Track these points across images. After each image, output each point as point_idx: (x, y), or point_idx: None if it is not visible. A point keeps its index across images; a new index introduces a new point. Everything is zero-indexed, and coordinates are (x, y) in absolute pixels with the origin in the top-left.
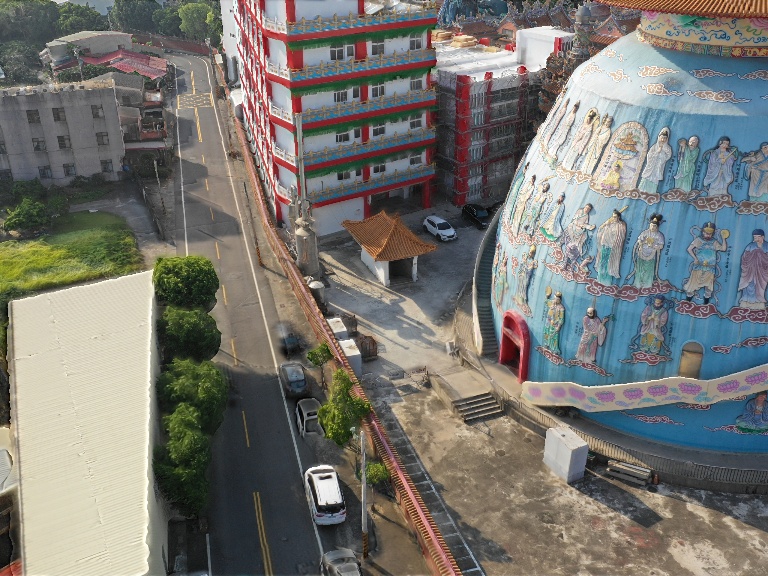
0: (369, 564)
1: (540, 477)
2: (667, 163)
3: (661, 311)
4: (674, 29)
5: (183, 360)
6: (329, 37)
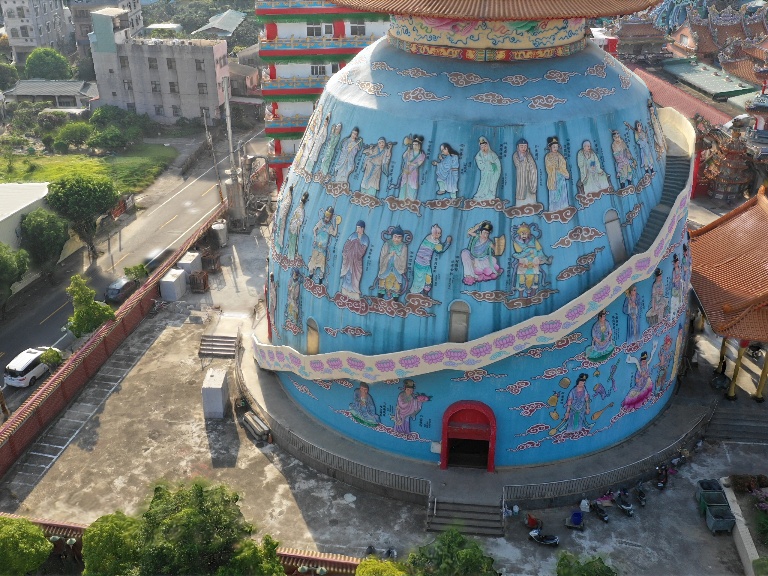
0: (4, 418)
1: (193, 407)
2: (322, 146)
3: (296, 284)
4: None
5: (31, 249)
6: (299, 14)
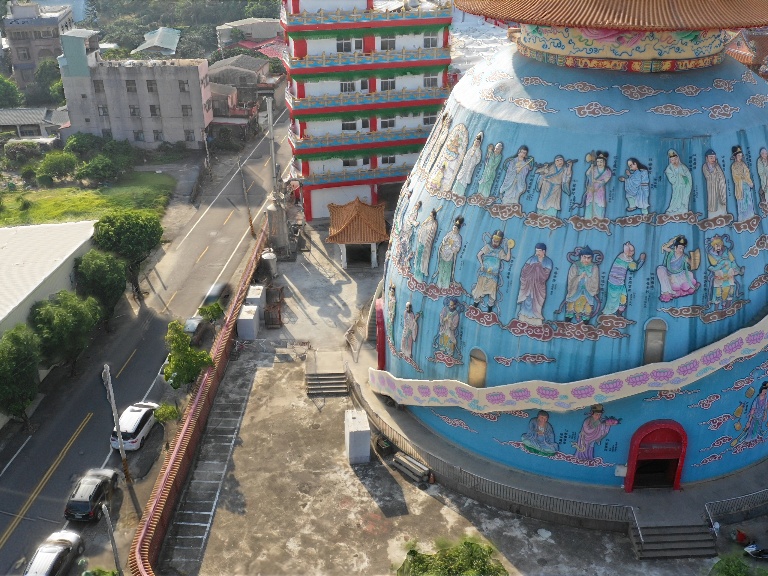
0: (128, 487)
1: (331, 453)
2: (476, 167)
3: (454, 313)
4: (527, 35)
5: None
6: (331, 30)
